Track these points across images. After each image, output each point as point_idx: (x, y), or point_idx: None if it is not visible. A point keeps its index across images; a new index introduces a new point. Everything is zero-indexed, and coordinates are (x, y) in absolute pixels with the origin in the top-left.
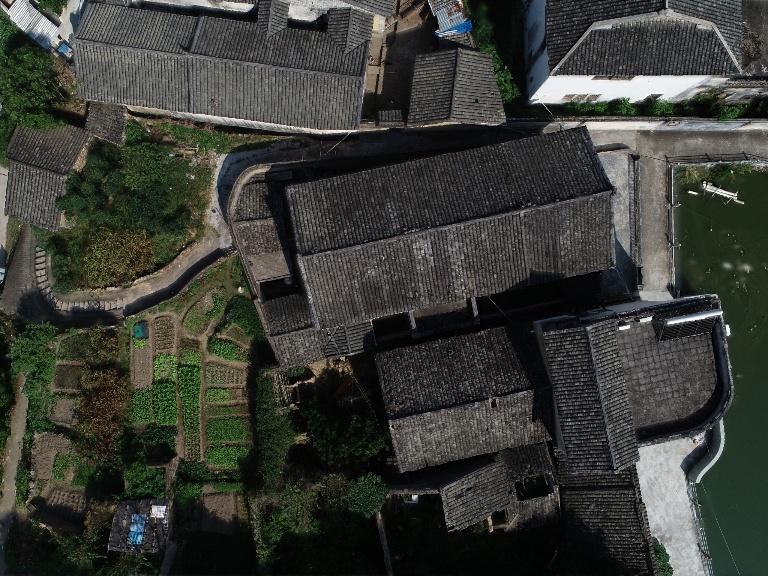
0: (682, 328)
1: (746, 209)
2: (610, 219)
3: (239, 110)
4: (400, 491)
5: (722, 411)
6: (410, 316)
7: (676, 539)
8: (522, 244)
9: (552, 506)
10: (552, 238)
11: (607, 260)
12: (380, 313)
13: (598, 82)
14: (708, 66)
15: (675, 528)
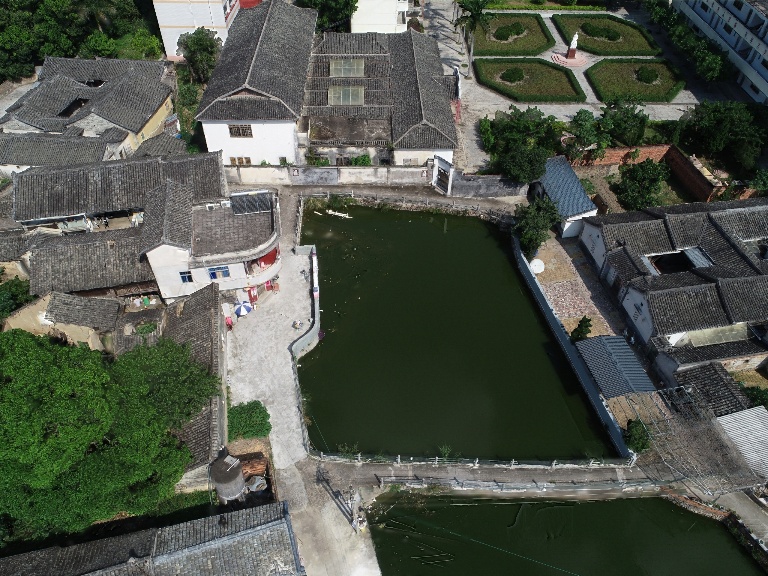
0: (246, 203)
1: (354, 221)
2: (219, 171)
3: (31, 160)
4: (24, 306)
5: (267, 240)
6: (86, 231)
7: (278, 403)
8: (160, 178)
9: (154, 342)
10: (181, 179)
11: (219, 195)
12: (59, 213)
13: (237, 140)
14: (280, 115)
15: (278, 394)
